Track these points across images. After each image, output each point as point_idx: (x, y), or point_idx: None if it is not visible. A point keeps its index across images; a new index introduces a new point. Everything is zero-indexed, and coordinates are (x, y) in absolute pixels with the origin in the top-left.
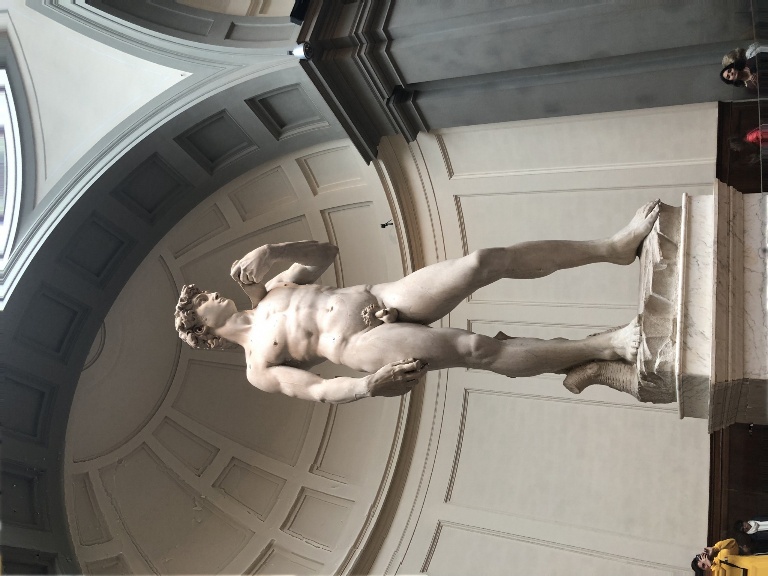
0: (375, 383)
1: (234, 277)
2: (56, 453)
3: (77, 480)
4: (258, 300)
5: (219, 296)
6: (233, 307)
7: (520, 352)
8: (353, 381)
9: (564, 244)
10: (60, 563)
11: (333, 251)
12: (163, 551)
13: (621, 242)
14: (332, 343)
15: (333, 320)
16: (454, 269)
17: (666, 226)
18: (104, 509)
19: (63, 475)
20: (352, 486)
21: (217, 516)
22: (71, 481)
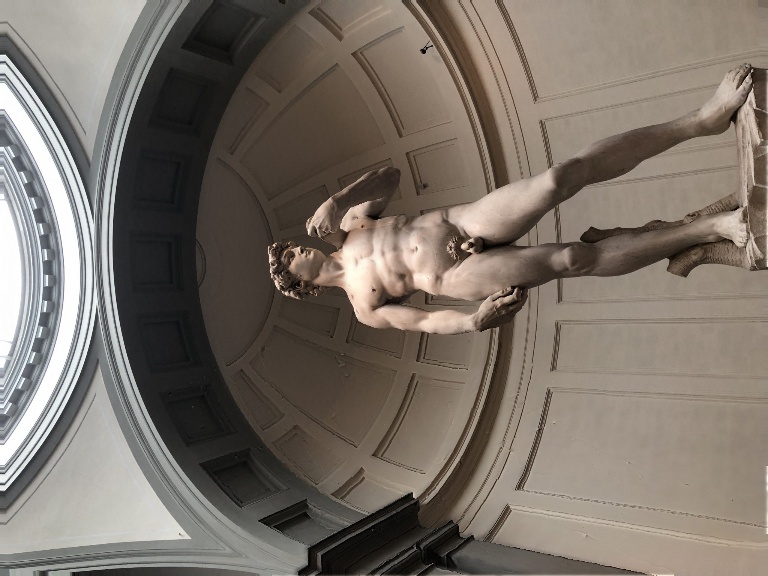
0: (482, 322)
1: (312, 235)
2: (211, 367)
3: (236, 379)
4: (341, 243)
5: (303, 249)
6: (320, 256)
7: (618, 257)
8: (459, 320)
9: (645, 136)
10: (255, 455)
11: (396, 176)
12: (328, 410)
13: (711, 119)
14: (427, 282)
15: (421, 262)
16: (531, 194)
17: (763, 99)
18: (267, 393)
19: (224, 382)
20: (469, 307)
21: (360, 367)
22: (232, 382)
